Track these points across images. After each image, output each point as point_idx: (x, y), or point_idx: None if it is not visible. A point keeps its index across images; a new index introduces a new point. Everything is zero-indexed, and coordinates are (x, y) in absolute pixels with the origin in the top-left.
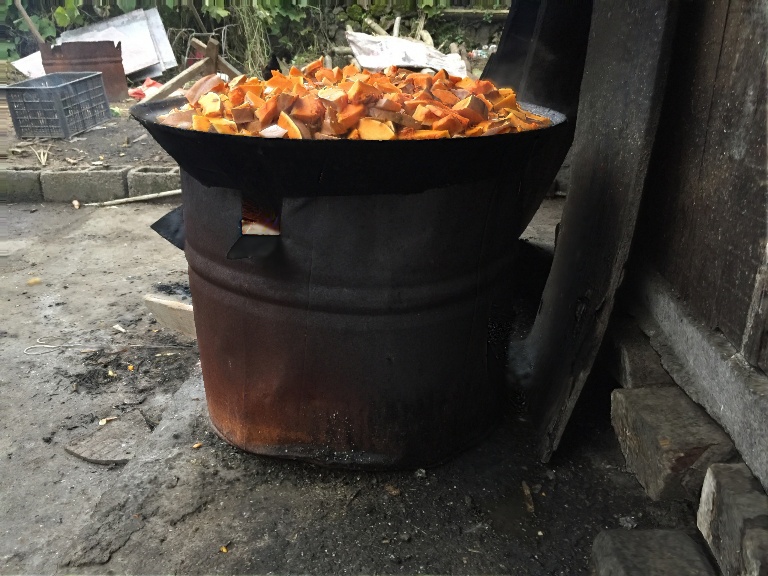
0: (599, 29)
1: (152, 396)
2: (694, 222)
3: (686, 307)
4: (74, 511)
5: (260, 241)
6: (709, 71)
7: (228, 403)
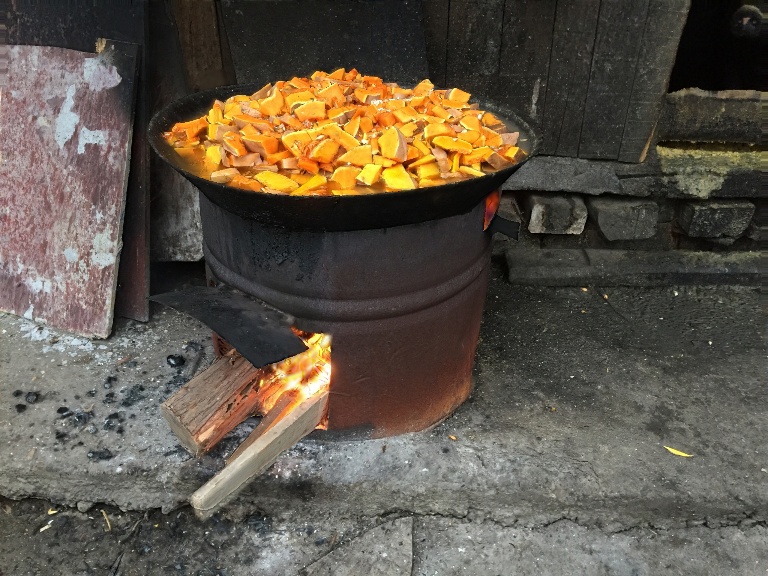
0: (257, 8)
1: (260, 573)
2: None
3: None
4: (484, 570)
5: (501, 222)
6: (438, 33)
7: (456, 381)
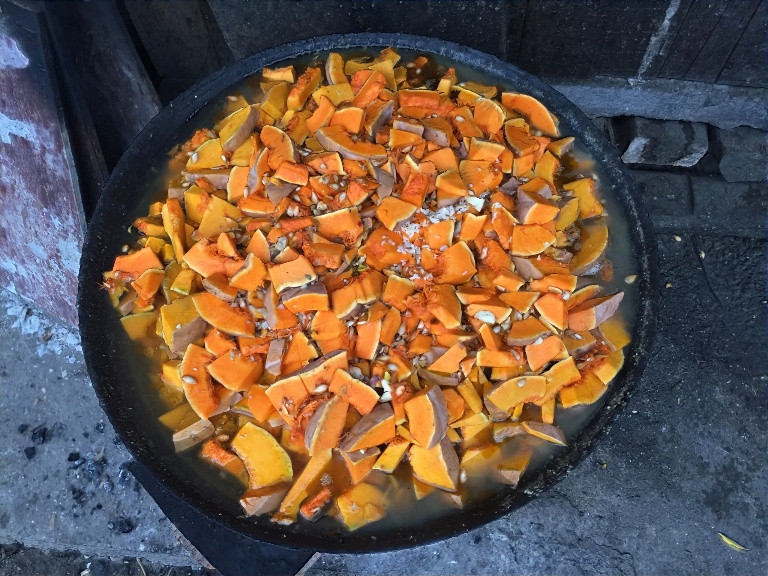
0: None
1: None
2: (530, 27)
3: (542, 79)
4: None
5: None
6: None
7: None
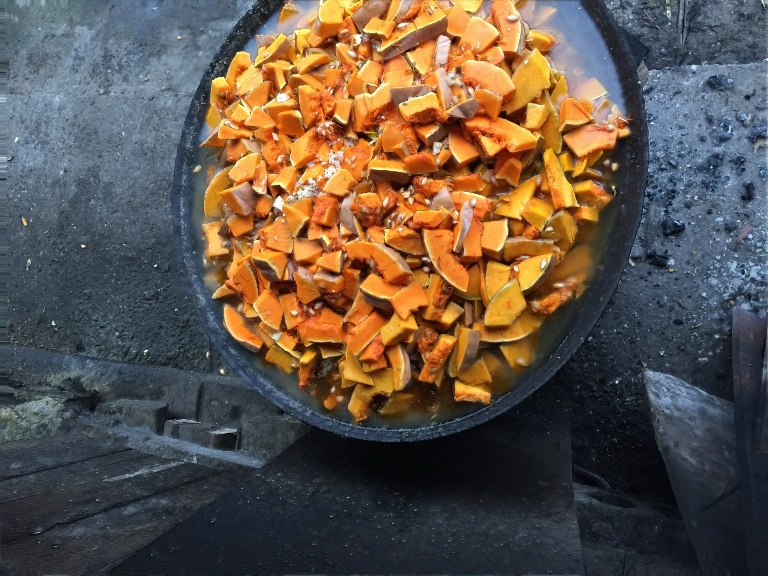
0: None
1: None
2: None
3: None
4: None
5: None
6: None
7: None
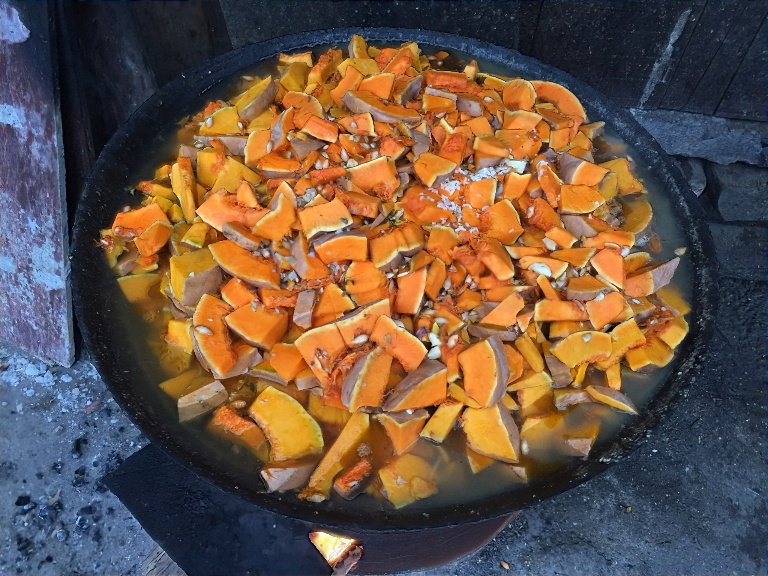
0: None
1: None
2: (538, 50)
3: None
4: None
5: None
6: None
7: None
